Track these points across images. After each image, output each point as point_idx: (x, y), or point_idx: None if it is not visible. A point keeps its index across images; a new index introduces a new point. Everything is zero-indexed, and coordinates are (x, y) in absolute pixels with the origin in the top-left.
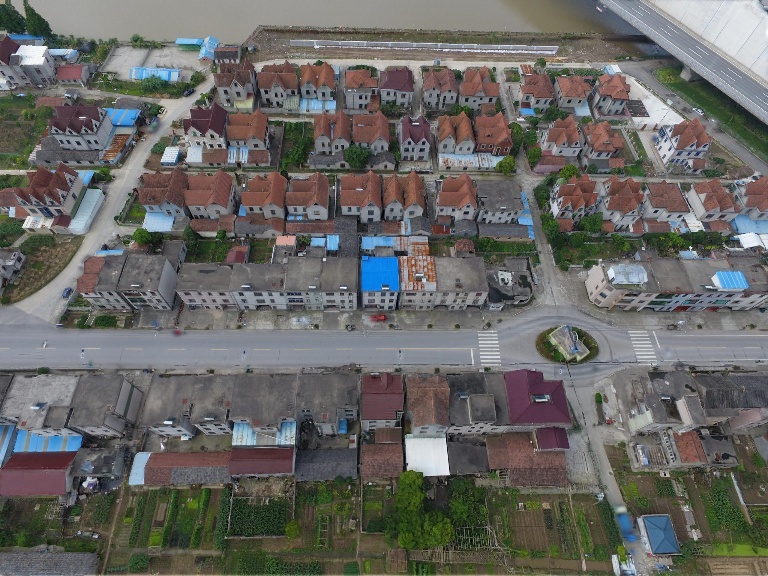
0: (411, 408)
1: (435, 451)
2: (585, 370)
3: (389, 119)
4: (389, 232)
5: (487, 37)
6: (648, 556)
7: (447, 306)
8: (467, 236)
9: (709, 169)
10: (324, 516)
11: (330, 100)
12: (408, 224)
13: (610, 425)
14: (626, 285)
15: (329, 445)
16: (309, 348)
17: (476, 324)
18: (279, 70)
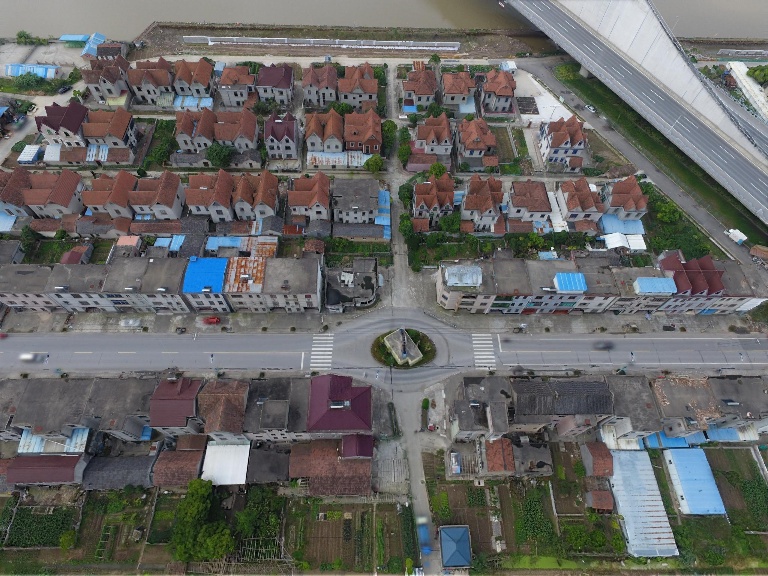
0: (204, 414)
1: (235, 459)
2: (418, 374)
3: (267, 116)
4: (238, 232)
5: (388, 33)
6: (444, 569)
7: (284, 308)
8: (321, 236)
9: (589, 167)
10: (108, 526)
11: (206, 97)
12: (260, 224)
13: (432, 432)
14: (462, 287)
15: (133, 452)
16: (133, 351)
17: (313, 327)
18: (152, 66)
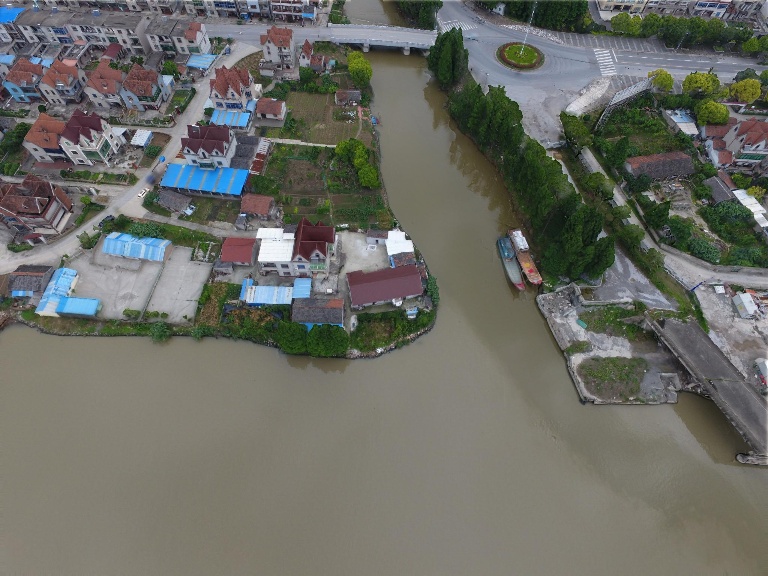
0: None
1: None
2: None
3: None
4: None
5: None
6: None
7: None
8: None
9: None
10: None
11: None
12: None
13: None
14: None
15: None
16: None
17: None
18: None
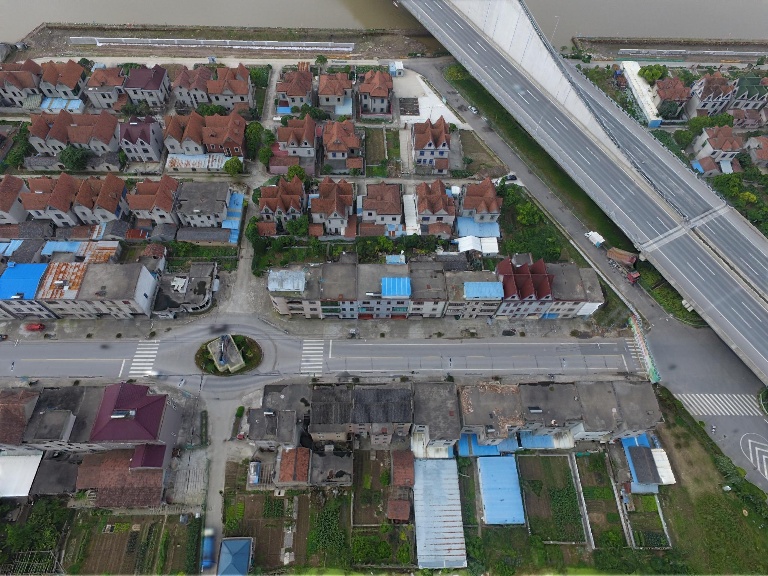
0: None
1: (24, 470)
2: (239, 382)
3: None
4: (78, 237)
5: (283, 34)
6: None
7: None
8: (166, 240)
9: (459, 169)
10: None
11: (76, 99)
12: (103, 228)
13: (242, 440)
14: (285, 292)
15: None
16: None
17: (141, 333)
18: (18, 68)
